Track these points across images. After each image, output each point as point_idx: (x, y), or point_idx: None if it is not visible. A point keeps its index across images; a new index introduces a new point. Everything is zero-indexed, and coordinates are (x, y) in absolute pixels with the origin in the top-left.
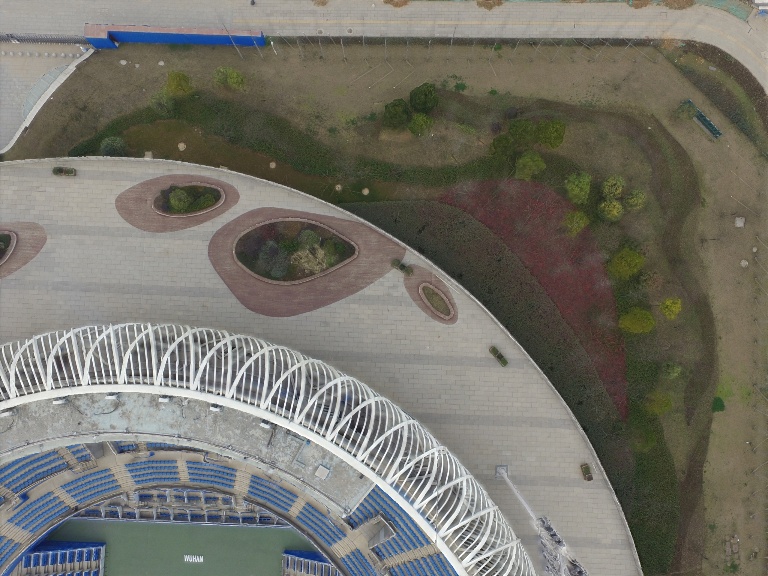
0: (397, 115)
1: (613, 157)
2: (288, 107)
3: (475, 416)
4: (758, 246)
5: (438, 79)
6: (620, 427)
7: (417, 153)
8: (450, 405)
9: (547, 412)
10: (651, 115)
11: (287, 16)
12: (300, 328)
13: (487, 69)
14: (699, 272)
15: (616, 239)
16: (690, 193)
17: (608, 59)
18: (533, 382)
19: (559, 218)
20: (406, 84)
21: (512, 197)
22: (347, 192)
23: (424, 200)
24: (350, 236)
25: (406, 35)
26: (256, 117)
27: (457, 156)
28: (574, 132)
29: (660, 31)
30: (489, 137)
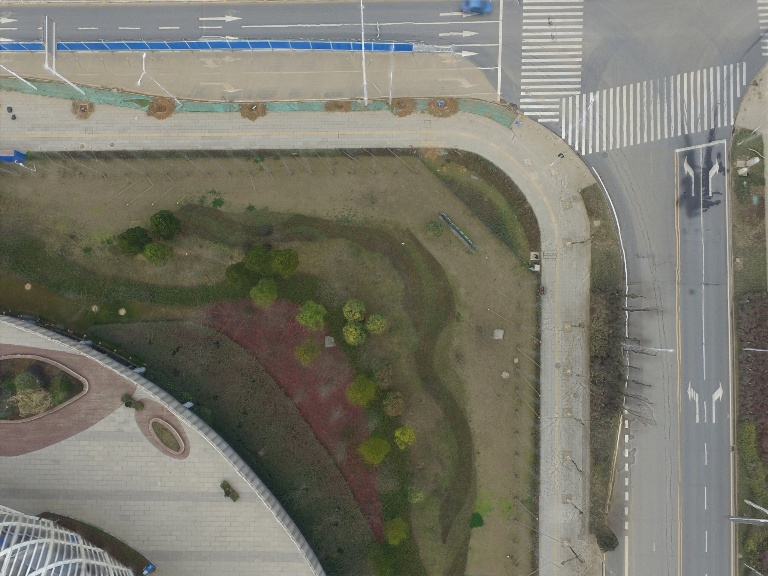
0: (125, 247)
1: (365, 275)
2: (44, 227)
3: (207, 552)
4: (519, 357)
5: (197, 195)
6: (374, 548)
7: (172, 273)
8: (181, 542)
9: (279, 546)
10: (406, 229)
11: (49, 130)
12: (29, 467)
13: (247, 183)
14: (455, 387)
15: (366, 359)
16: (444, 309)
17: (369, 170)
18: (265, 516)
19: (312, 337)
20: (164, 200)
21: (267, 316)
22: (103, 313)
23: (177, 321)
24: (80, 371)
25: (169, 148)
26: (10, 238)
27: (211, 275)
28: (327, 249)
29: (424, 140)
30: (242, 256)
